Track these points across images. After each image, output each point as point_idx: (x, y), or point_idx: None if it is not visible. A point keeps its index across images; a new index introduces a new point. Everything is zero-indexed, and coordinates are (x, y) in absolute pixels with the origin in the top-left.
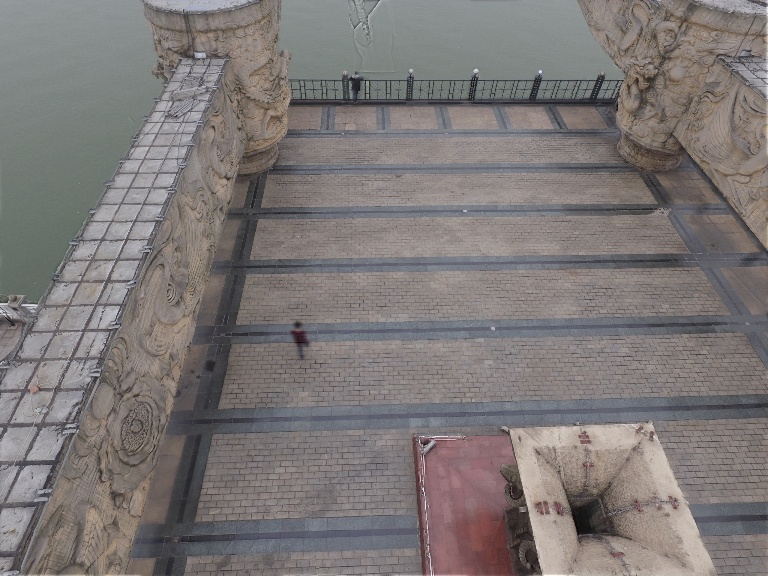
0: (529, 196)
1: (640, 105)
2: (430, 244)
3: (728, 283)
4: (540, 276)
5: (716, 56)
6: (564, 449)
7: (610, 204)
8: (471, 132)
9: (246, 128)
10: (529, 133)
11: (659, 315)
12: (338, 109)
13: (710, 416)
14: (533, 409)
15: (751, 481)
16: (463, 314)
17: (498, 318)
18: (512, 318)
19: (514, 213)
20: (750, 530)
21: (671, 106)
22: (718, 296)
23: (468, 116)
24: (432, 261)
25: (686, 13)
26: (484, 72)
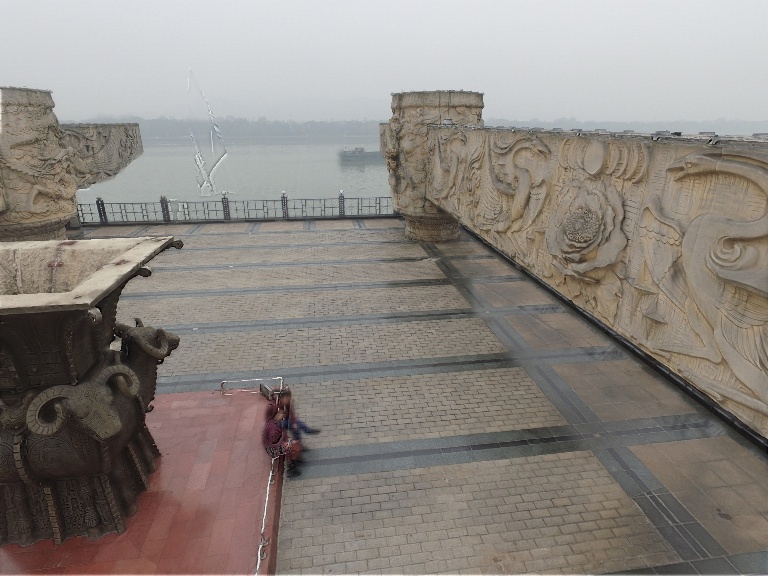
0: (304, 257)
1: (397, 181)
2: (175, 284)
3: (477, 291)
4: (279, 296)
5: (427, 126)
6: (29, 250)
7: (382, 258)
8: (274, 232)
9: (8, 198)
10: (329, 231)
11: (394, 312)
12: (156, 227)
13: (415, 372)
14: (193, 380)
15: (443, 419)
16: (169, 321)
17: (208, 322)
18: (224, 321)
19: (281, 266)
20: (422, 463)
21: (415, 174)
22: (463, 298)
23: (278, 226)
24: (166, 293)
25: (398, 103)
26: (292, 194)
